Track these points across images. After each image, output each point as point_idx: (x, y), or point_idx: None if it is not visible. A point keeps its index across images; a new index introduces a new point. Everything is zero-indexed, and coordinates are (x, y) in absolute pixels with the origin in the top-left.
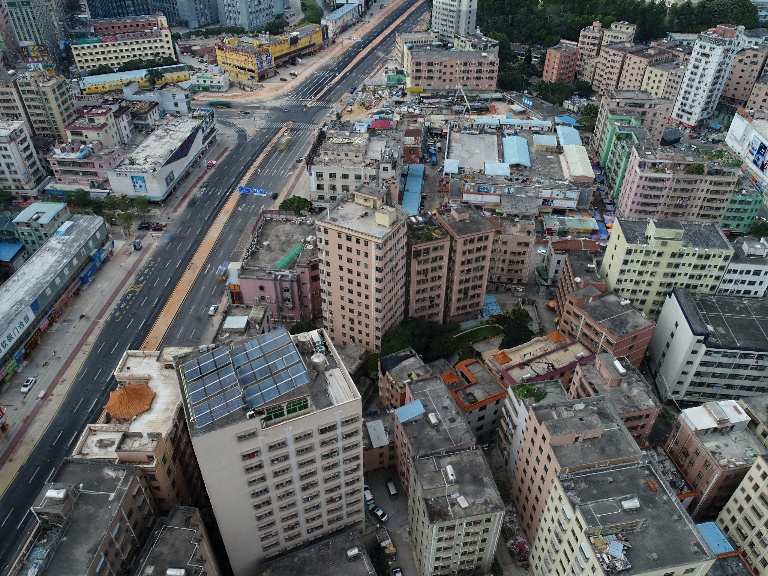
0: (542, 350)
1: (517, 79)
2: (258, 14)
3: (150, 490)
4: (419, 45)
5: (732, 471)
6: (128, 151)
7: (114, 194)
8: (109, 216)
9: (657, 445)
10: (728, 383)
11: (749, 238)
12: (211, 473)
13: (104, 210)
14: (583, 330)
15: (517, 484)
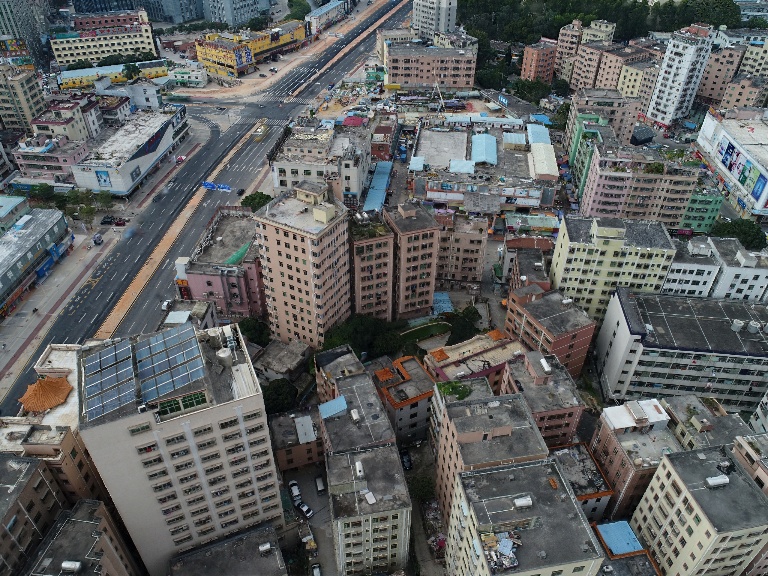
0: (482, 348)
1: (495, 77)
2: (243, 10)
3: (57, 483)
4: (399, 42)
5: (646, 470)
6: (96, 146)
7: (78, 189)
8: (70, 210)
9: (580, 444)
10: (668, 383)
11: (703, 238)
12: (106, 466)
13: (68, 204)
14: (525, 328)
15: (438, 481)
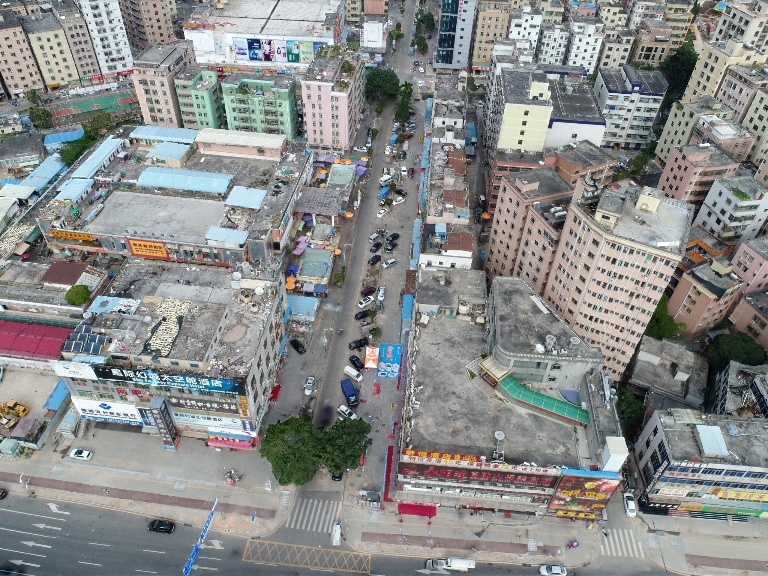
0: None
1: None
2: None
3: None
4: None
5: None
6: None
7: None
8: None
9: None
10: None
11: None
12: None
13: None
14: None
15: None
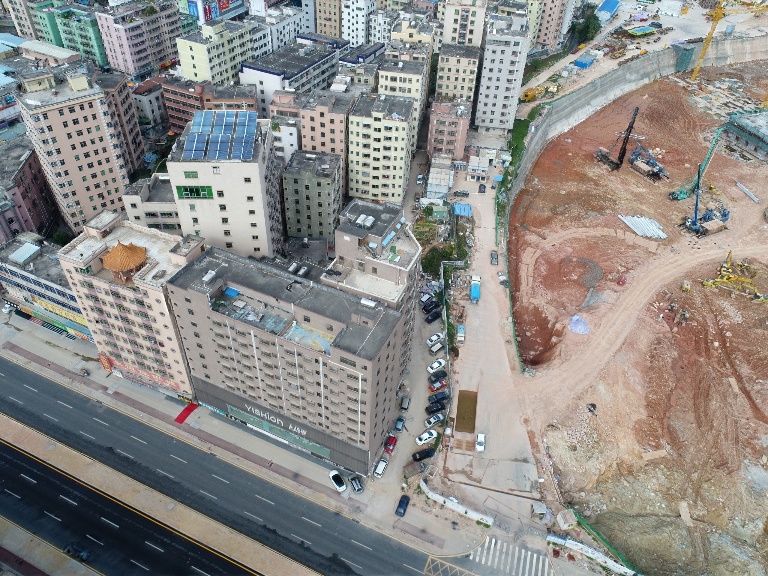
0: None
1: None
2: None
3: None
4: None
5: None
6: None
7: None
8: None
9: None
10: None
11: None
12: None
13: None
14: None
15: None
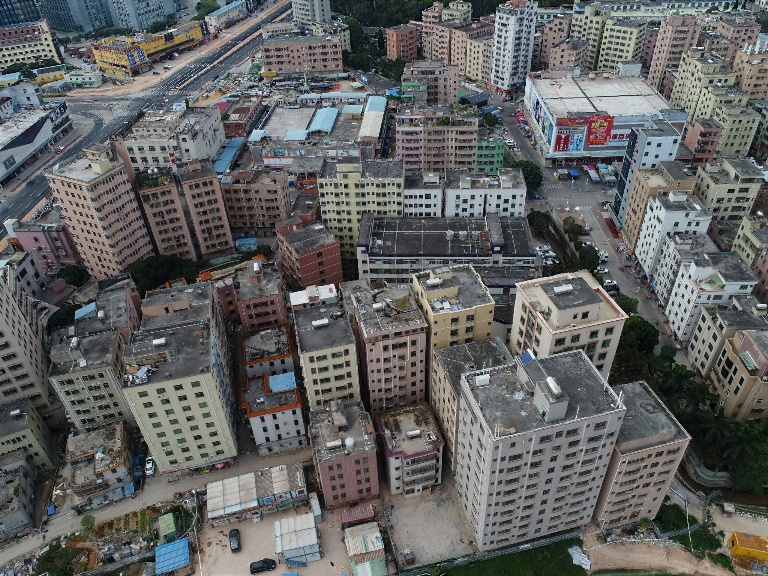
0: None
1: (363, 59)
2: (148, 15)
3: None
4: (280, 34)
5: None
6: None
7: None
8: None
9: (282, 325)
10: None
11: None
12: None
13: None
14: None
15: None
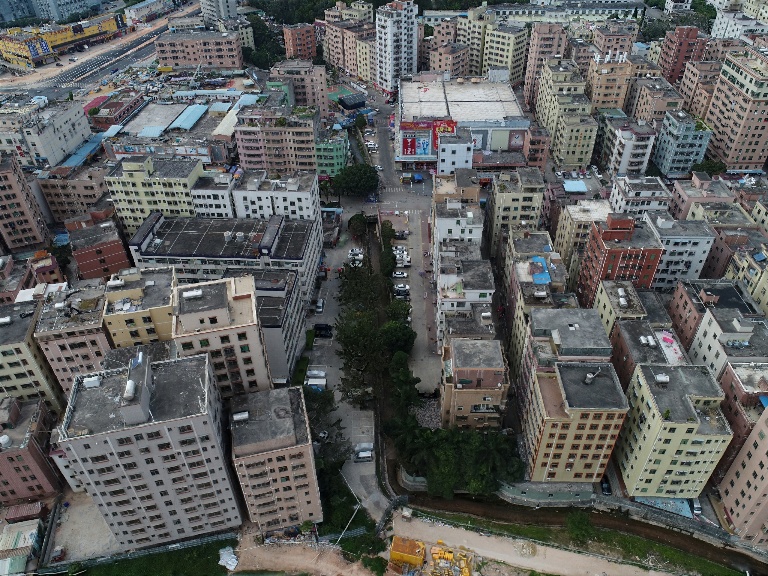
0: None
1: (262, 57)
2: (69, 6)
3: None
4: (185, 29)
5: None
6: None
7: None
8: None
9: None
10: None
11: (289, 176)
12: None
13: None
14: None
15: None
